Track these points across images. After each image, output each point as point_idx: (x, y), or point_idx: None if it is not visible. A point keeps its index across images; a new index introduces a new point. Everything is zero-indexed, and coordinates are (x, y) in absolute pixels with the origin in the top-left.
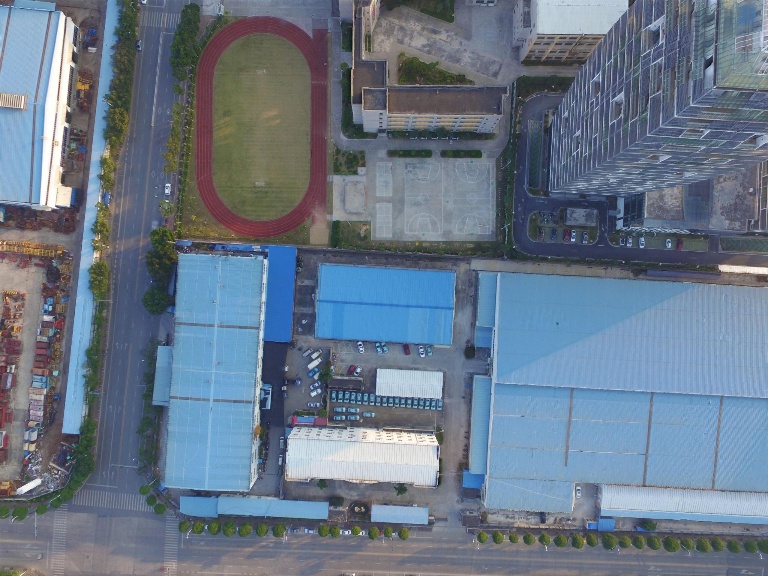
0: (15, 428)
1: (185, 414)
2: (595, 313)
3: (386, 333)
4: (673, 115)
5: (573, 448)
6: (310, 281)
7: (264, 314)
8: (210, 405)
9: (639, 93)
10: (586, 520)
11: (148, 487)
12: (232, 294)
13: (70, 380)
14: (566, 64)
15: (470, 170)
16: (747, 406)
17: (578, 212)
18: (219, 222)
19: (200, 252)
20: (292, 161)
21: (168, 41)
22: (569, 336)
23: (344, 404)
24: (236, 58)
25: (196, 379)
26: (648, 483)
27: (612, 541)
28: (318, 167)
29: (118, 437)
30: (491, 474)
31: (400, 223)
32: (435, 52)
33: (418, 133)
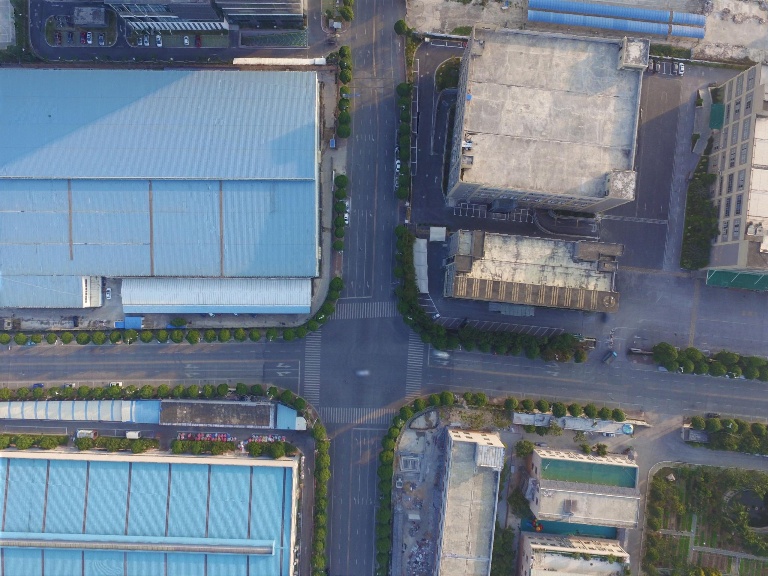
0: None
1: None
2: (88, 104)
3: None
4: None
5: (76, 241)
6: None
7: None
8: None
9: None
10: None
11: None
12: None
13: None
14: None
15: None
16: (247, 190)
17: (85, 11)
18: None
19: None
20: None
21: None
22: (61, 128)
23: None
24: None
25: None
26: (156, 273)
27: (126, 334)
28: None
29: None
30: None
31: None
32: None
33: None
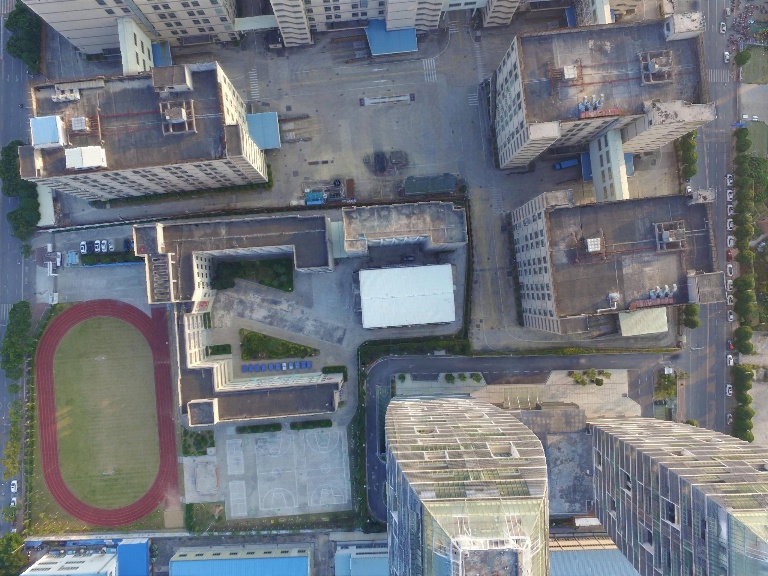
0: None
1: None
2: None
3: None
4: None
5: None
6: (167, 567)
7: None
8: None
9: None
10: None
11: None
12: None
13: None
14: None
15: (321, 440)
16: None
17: None
18: (70, 514)
19: (52, 549)
20: (140, 445)
21: (3, 333)
22: None
23: None
24: (75, 345)
25: None
26: None
27: None
28: (167, 449)
29: None
30: None
31: (254, 500)
32: (277, 323)
33: None
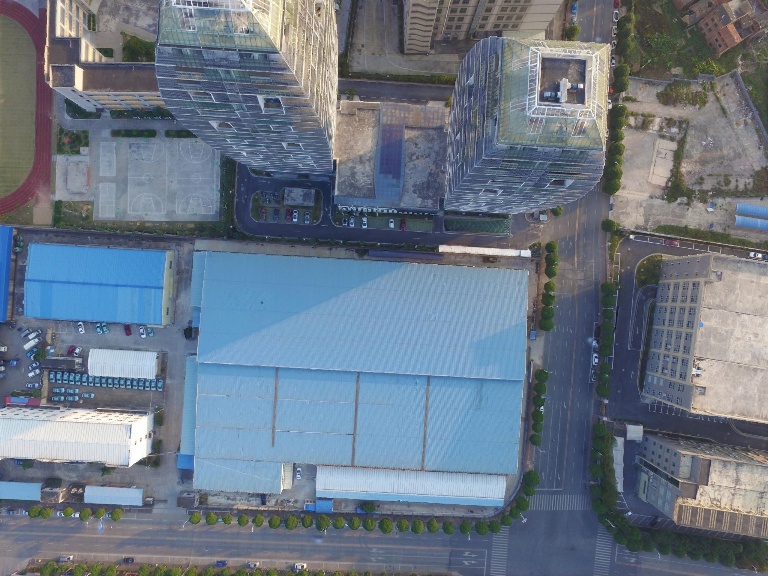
0: None
1: None
2: (301, 292)
3: (95, 312)
4: None
5: (279, 428)
6: None
7: None
8: None
9: None
10: (306, 502)
11: None
12: None
13: None
14: None
15: (195, 150)
16: (455, 386)
17: (295, 192)
18: None
19: None
20: (16, 141)
21: None
22: (273, 315)
23: (64, 385)
24: None
25: None
26: (357, 463)
27: (322, 522)
28: (43, 147)
29: None
30: (197, 454)
31: (123, 203)
32: None
33: (135, 112)
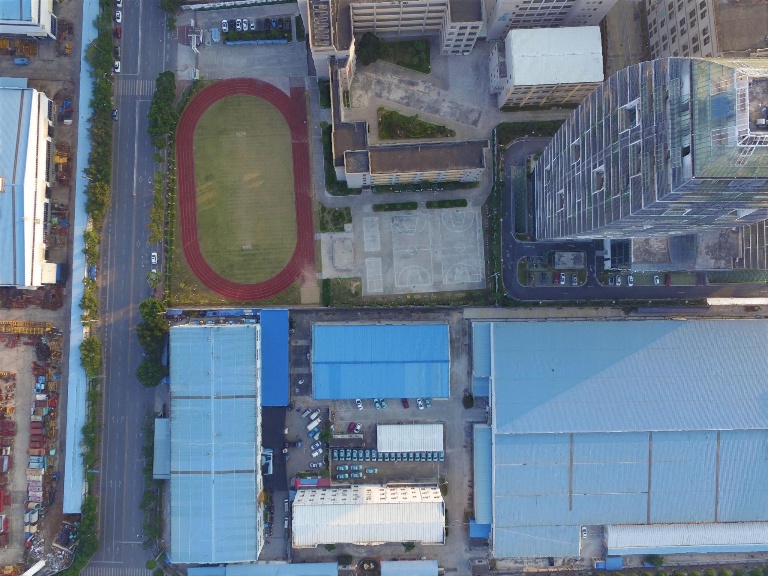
0: (15, 510)
1: (187, 488)
2: (589, 357)
3: (384, 390)
4: (654, 200)
5: (576, 492)
6: (304, 341)
7: (260, 380)
8: (212, 477)
9: (619, 171)
10: (594, 560)
11: (154, 561)
12: (226, 364)
13: (68, 459)
14: (544, 108)
15: (456, 219)
16: (744, 438)
17: (566, 256)
18: (208, 288)
19: (191, 320)
20: (278, 221)
21: (145, 108)
22: (565, 382)
23: (346, 462)
24: (215, 121)
25: (196, 452)
26: (652, 521)
27: None
28: (304, 226)
29: (120, 512)
30: (497, 524)
31: (390, 277)
32: (414, 104)
33: (402, 187)
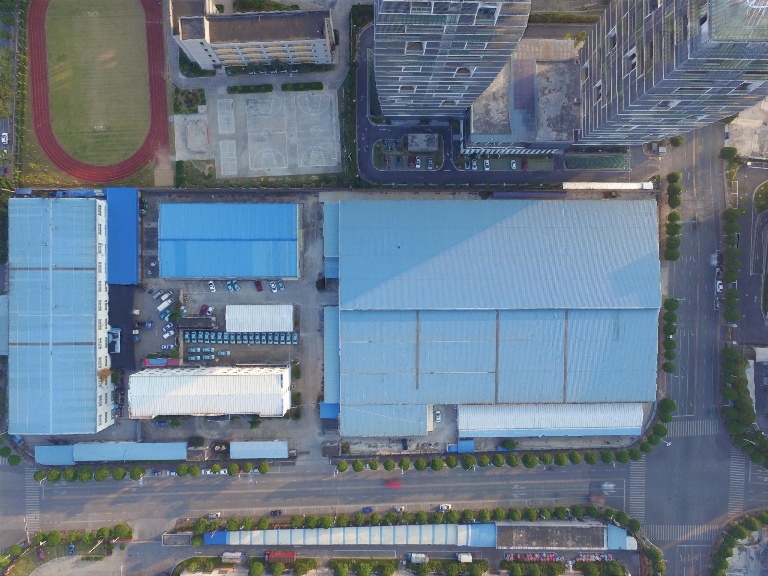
0: None
1: (25, 360)
2: (436, 235)
3: (231, 268)
4: None
5: (423, 370)
6: (157, 223)
7: (106, 257)
8: (50, 349)
9: None
10: (447, 443)
11: (0, 439)
12: (65, 236)
13: None
14: None
15: (312, 102)
16: (592, 318)
17: (419, 137)
18: (60, 169)
19: None
20: (131, 103)
21: None
22: (411, 259)
23: (199, 344)
24: (67, 2)
25: (34, 324)
26: (500, 400)
27: (469, 460)
28: (159, 108)
29: None
30: (343, 402)
31: (244, 160)
32: None
33: (254, 66)
